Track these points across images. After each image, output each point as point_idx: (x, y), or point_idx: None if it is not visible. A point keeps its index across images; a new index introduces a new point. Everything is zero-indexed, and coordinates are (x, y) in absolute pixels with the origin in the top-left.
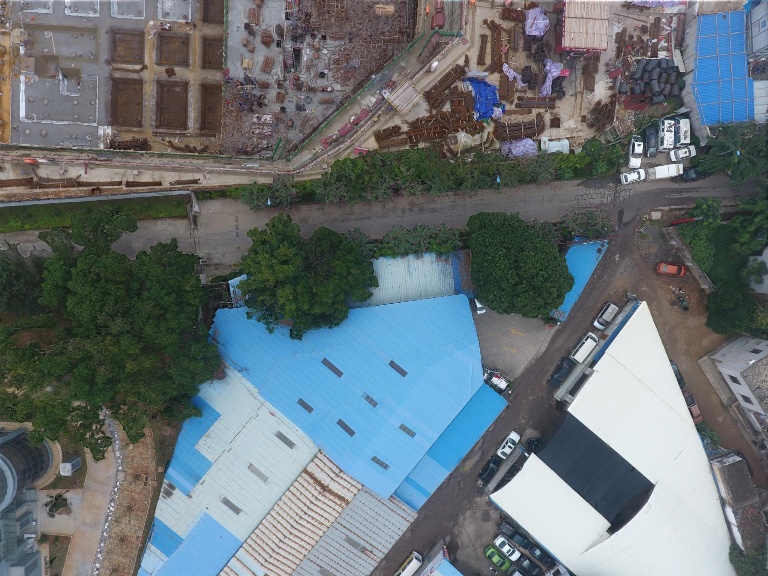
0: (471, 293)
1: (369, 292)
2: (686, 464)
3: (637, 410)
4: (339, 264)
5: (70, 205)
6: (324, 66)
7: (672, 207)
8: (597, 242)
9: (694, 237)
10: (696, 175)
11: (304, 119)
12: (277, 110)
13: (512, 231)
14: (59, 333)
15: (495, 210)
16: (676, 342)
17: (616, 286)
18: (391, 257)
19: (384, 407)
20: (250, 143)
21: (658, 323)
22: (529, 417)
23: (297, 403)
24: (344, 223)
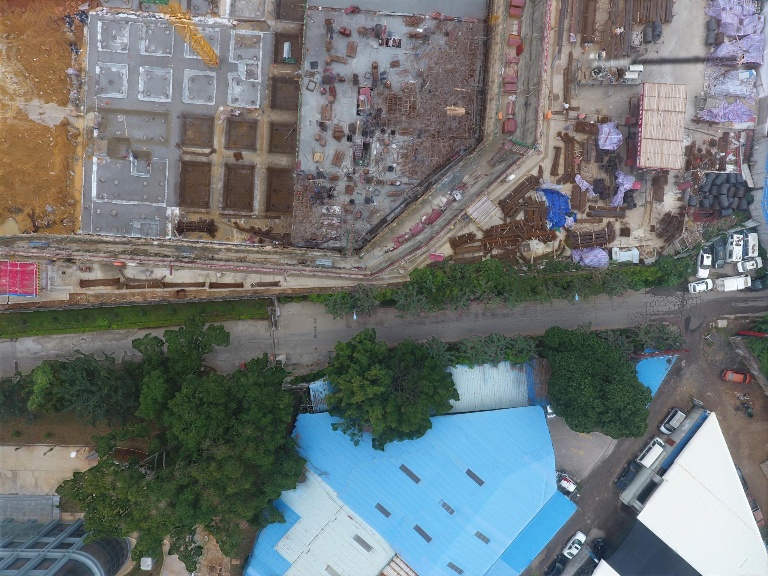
0: (544, 401)
1: (450, 405)
2: (751, 571)
3: (704, 518)
4: (426, 384)
5: (155, 306)
6: (393, 160)
7: (738, 315)
8: (669, 356)
9: (762, 350)
10: (763, 286)
11: (372, 211)
12: (346, 202)
13: (592, 352)
14: (155, 445)
15: (565, 316)
16: (739, 446)
17: (682, 391)
18: (468, 367)
19: (460, 515)
20: (319, 233)
21: (722, 427)
22: (594, 517)
23: (375, 507)
24: (419, 326)
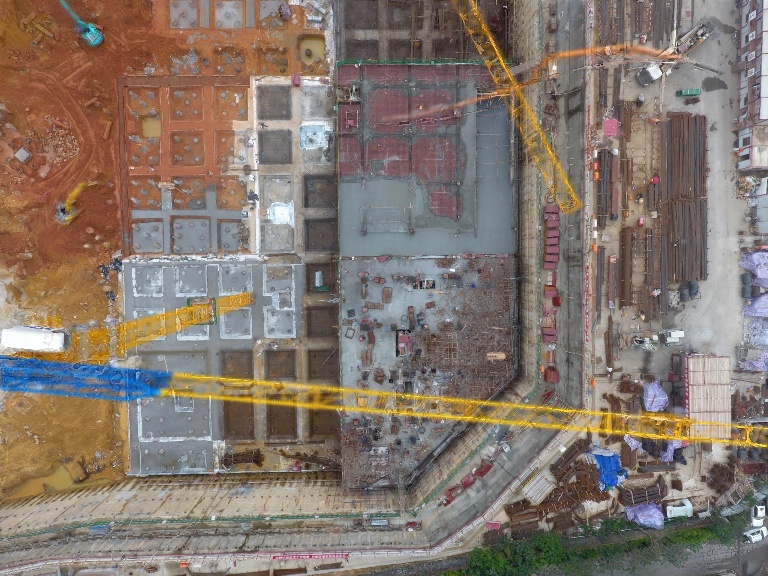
0: None
1: None
2: None
3: None
4: None
5: None
6: None
7: None
8: None
9: None
10: None
11: None
12: (392, 441)
13: None
14: None
15: (624, 572)
16: None
17: None
18: None
19: None
20: (368, 474)
21: None
22: None
23: None
24: None
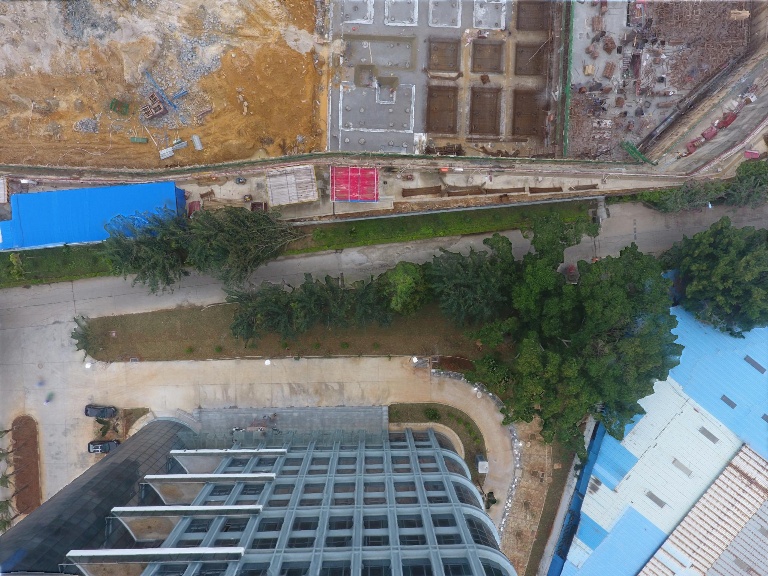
0: None
1: None
2: None
3: None
4: None
5: (479, 212)
6: (662, 71)
7: None
8: None
9: None
10: None
11: (643, 123)
12: (616, 115)
13: None
14: (536, 336)
15: None
16: None
17: None
18: None
19: None
20: (590, 147)
21: None
22: None
23: (720, 399)
24: (737, 224)
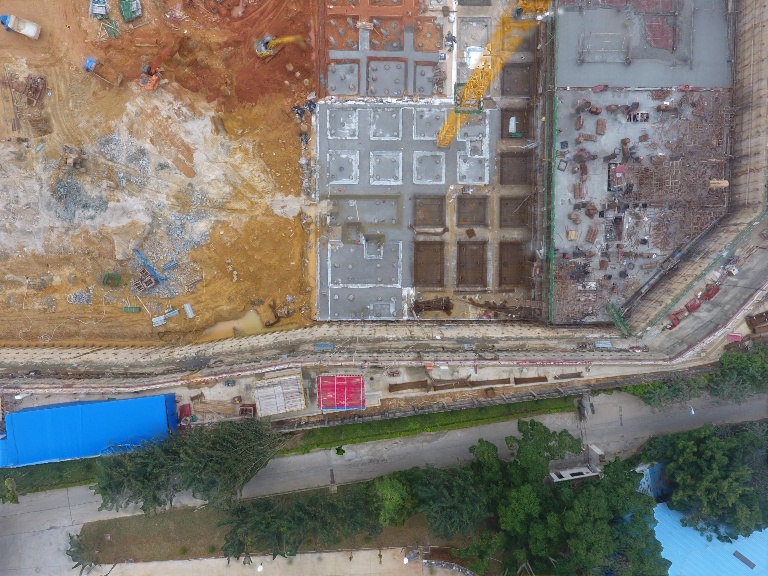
0: None
1: None
2: None
3: None
4: None
5: None
6: (644, 233)
7: None
8: None
9: None
10: None
11: (628, 285)
12: (601, 277)
13: None
14: (523, 557)
15: None
16: None
17: None
18: None
19: None
20: (576, 310)
21: None
22: None
23: None
24: (722, 407)
